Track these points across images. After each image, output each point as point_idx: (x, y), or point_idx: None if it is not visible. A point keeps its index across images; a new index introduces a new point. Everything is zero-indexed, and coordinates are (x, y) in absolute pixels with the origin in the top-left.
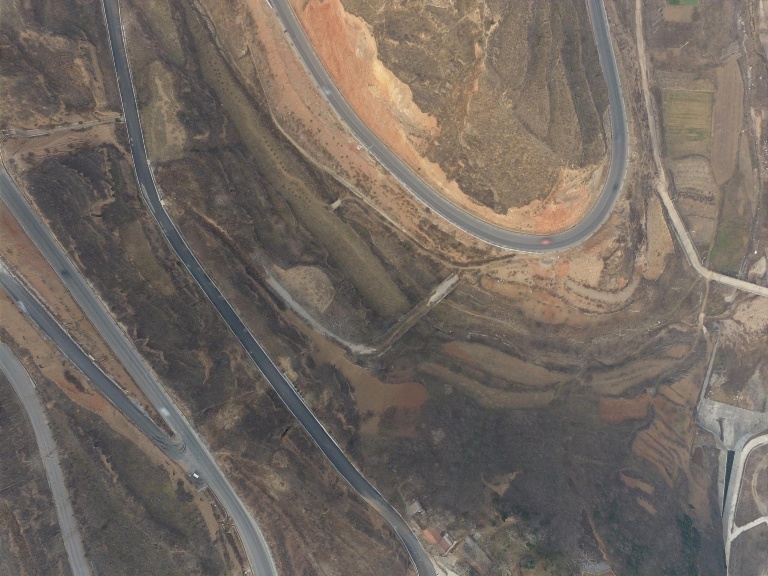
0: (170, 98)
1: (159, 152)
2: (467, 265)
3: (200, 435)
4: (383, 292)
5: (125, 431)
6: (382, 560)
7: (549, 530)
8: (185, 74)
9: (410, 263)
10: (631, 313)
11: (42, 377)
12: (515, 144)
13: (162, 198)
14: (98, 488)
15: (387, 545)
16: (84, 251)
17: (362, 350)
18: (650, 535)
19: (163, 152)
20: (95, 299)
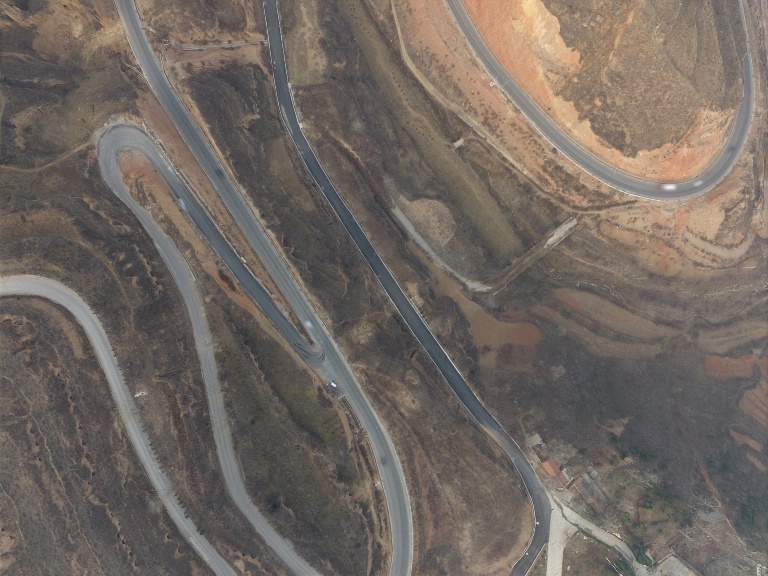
0: (313, 25)
1: (300, 76)
2: (587, 209)
3: (339, 346)
4: (498, 234)
5: (272, 333)
6: (503, 487)
7: (665, 474)
8: (325, 5)
9: (526, 206)
10: (744, 270)
11: (202, 271)
12: (659, 81)
13: (300, 121)
14: (248, 384)
15: (509, 473)
16: (237, 159)
17: (478, 287)
18: (762, 490)
19: (304, 76)
20: (245, 206)
